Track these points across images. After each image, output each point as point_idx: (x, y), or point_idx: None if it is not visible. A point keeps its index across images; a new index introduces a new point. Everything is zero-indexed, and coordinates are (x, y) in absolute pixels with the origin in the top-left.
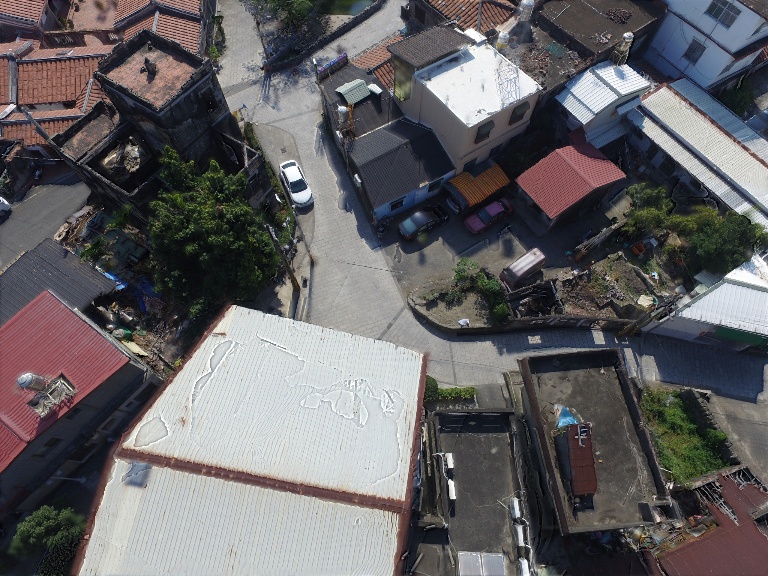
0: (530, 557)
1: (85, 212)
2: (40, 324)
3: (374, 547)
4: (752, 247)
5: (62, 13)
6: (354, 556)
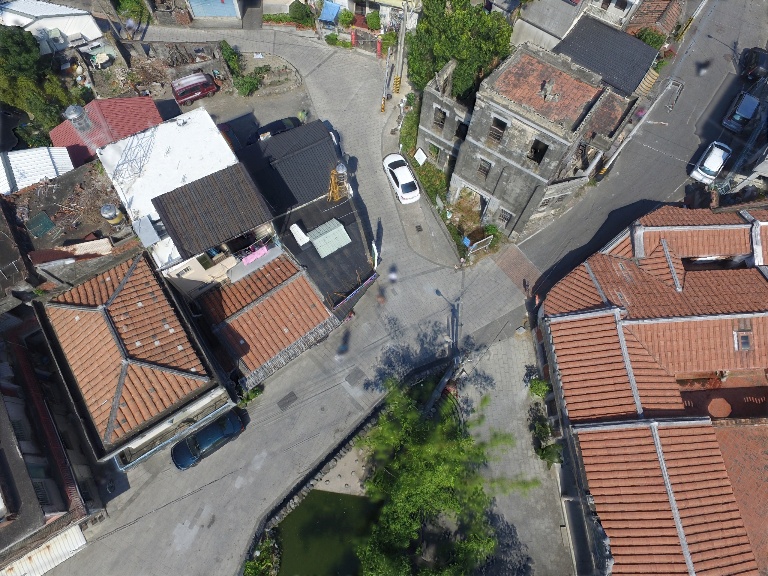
0: None
1: None
2: None
3: None
4: None
5: None
6: None
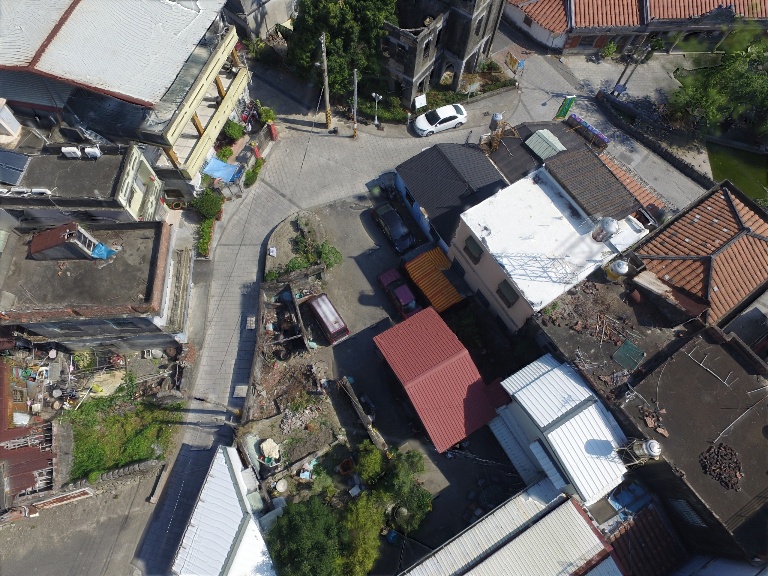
0: (3, 195)
1: None
2: None
3: (8, 45)
4: (285, 571)
5: None
6: (7, 35)
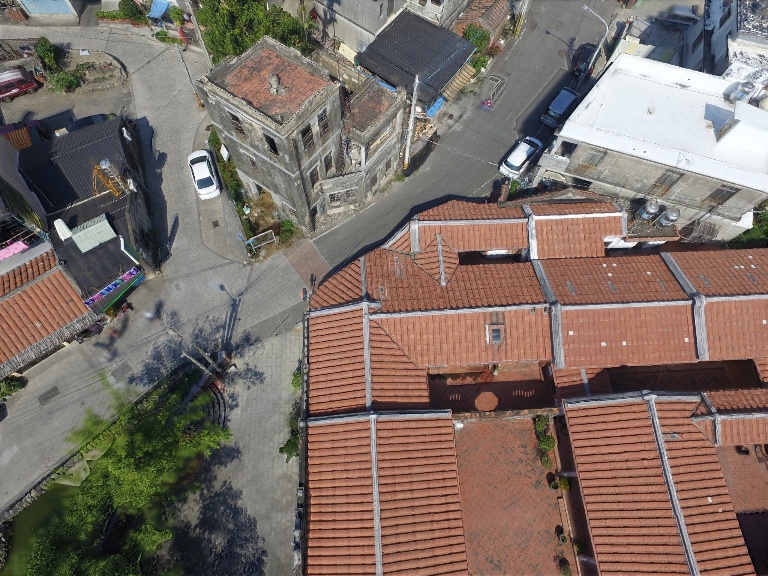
0: None
1: (414, 146)
2: None
3: None
4: None
5: (579, 515)
6: None
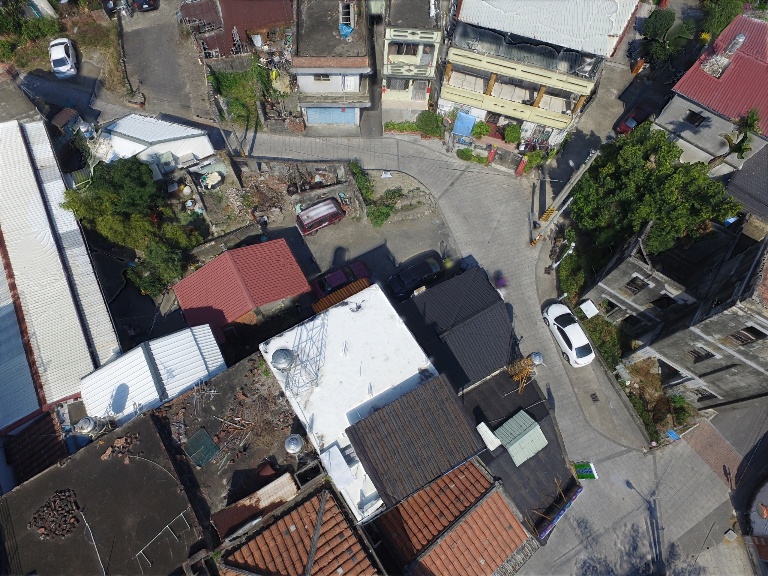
0: None
1: None
2: (759, 113)
3: None
4: None
5: None
6: None
